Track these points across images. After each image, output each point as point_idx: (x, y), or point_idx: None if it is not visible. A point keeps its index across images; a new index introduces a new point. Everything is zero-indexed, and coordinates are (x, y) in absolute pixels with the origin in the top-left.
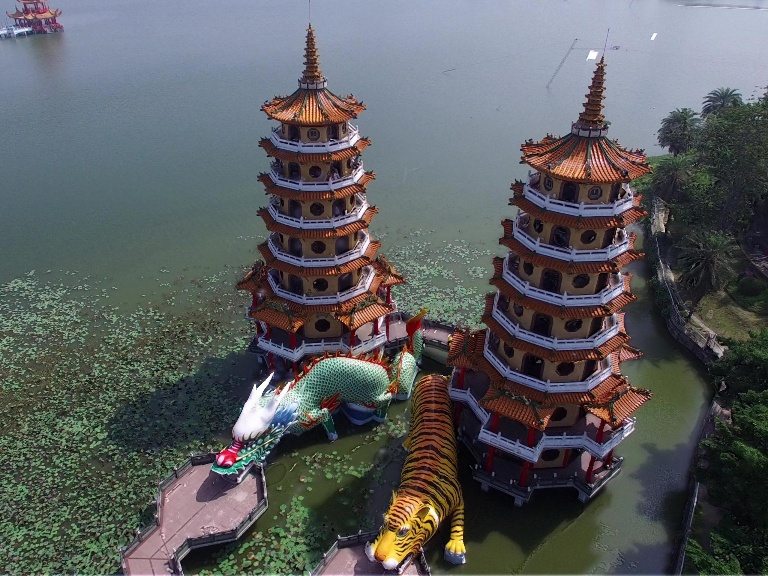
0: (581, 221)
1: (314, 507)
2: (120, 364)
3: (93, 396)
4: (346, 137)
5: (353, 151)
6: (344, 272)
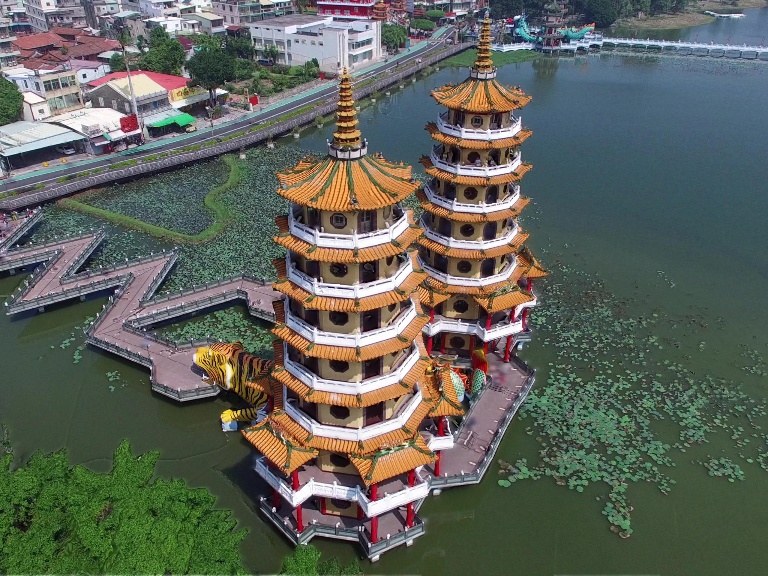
0: (284, 218)
1: None
2: None
3: None
4: None
5: None
6: (421, 243)
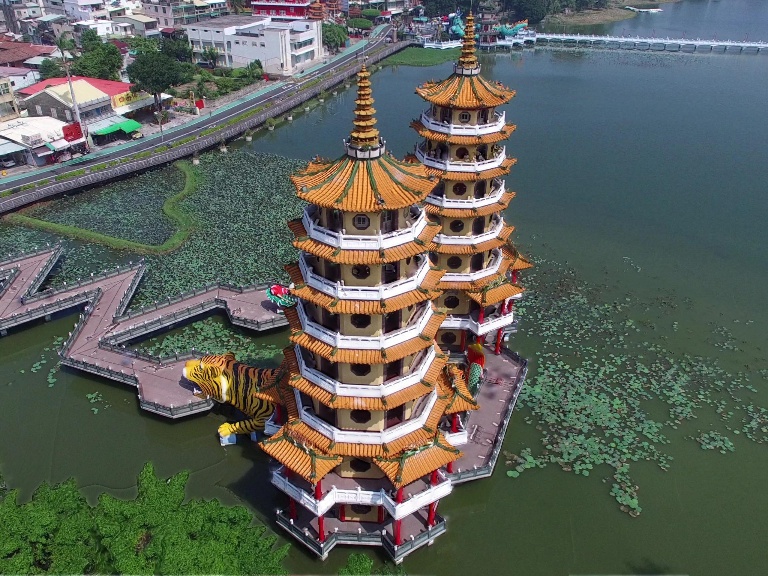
0: (297, 222)
1: (275, 360)
2: None
3: None
4: (458, 125)
5: (445, 137)
6: None
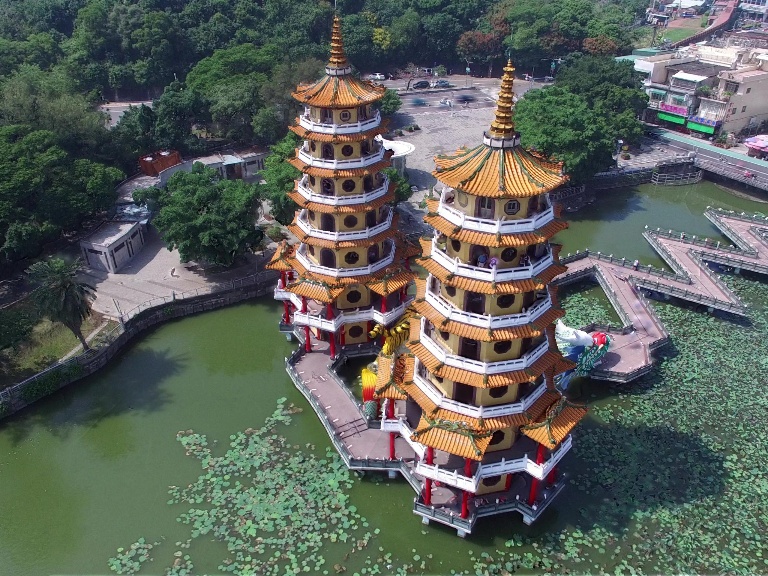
0: None
1: None
2: (752, 572)
3: (767, 524)
4: None
5: None
6: None
